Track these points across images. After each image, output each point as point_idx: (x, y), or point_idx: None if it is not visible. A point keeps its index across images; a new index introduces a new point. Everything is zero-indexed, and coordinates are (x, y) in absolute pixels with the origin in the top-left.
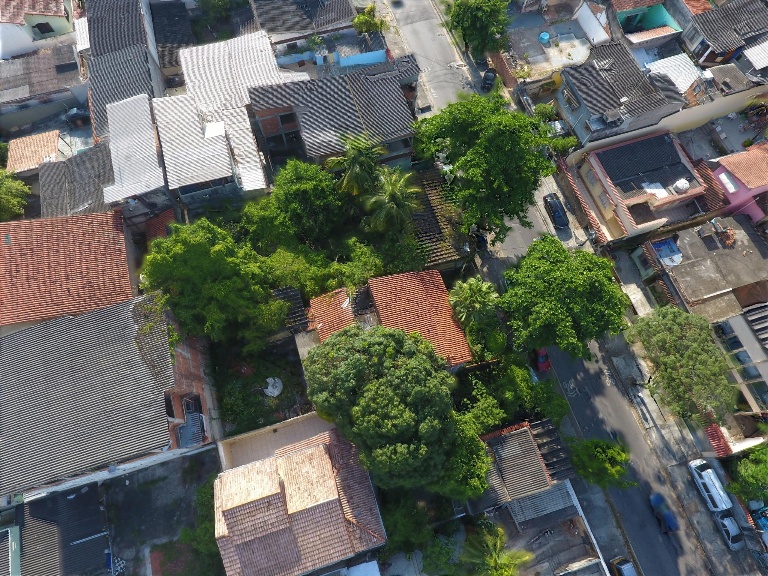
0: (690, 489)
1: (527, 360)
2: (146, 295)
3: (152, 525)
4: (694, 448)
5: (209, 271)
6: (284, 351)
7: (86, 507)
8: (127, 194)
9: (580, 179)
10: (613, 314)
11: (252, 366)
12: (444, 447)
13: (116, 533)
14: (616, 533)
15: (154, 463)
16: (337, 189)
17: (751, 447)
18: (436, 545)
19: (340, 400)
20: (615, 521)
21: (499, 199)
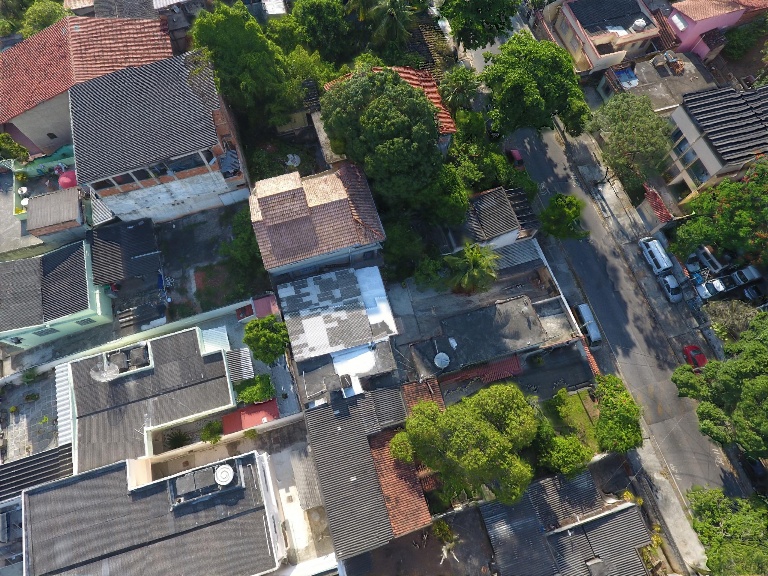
0: (640, 261)
1: (504, 154)
2: (195, 50)
3: (195, 254)
4: (644, 230)
5: (243, 45)
6: (301, 141)
7: (143, 234)
8: (173, 1)
9: (555, 33)
10: (571, 84)
11: (275, 146)
12: (432, 161)
13: (166, 260)
14: (577, 291)
15: (197, 207)
16: (346, 10)
17: (688, 216)
18: (425, 259)
19: (350, 114)
20: (576, 283)
21: (481, 12)
